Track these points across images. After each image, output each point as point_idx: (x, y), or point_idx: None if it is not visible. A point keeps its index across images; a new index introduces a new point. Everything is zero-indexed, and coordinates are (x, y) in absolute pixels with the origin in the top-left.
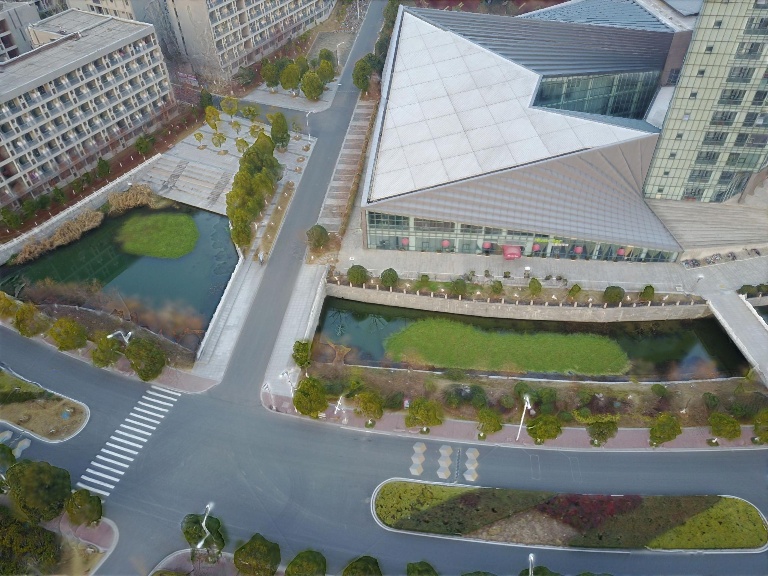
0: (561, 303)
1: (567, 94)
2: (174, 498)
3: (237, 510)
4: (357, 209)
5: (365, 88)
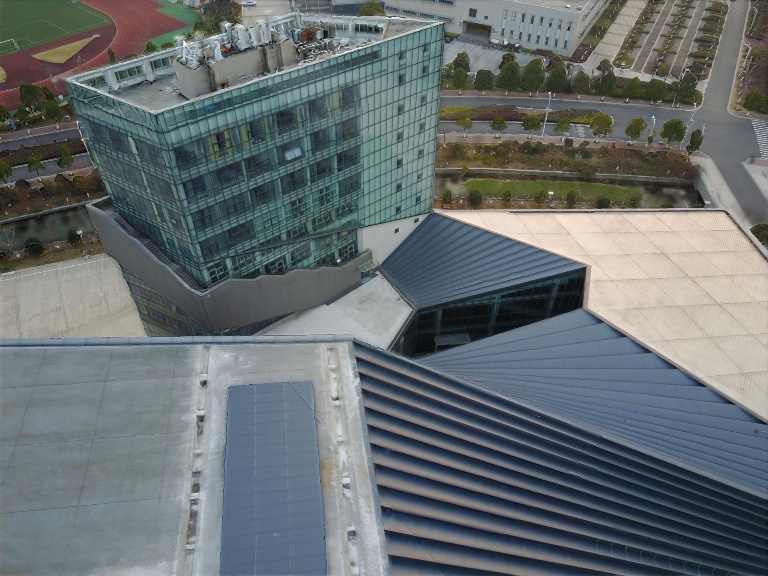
0: (516, 196)
1: None
2: (717, 122)
3: None
4: None
5: None
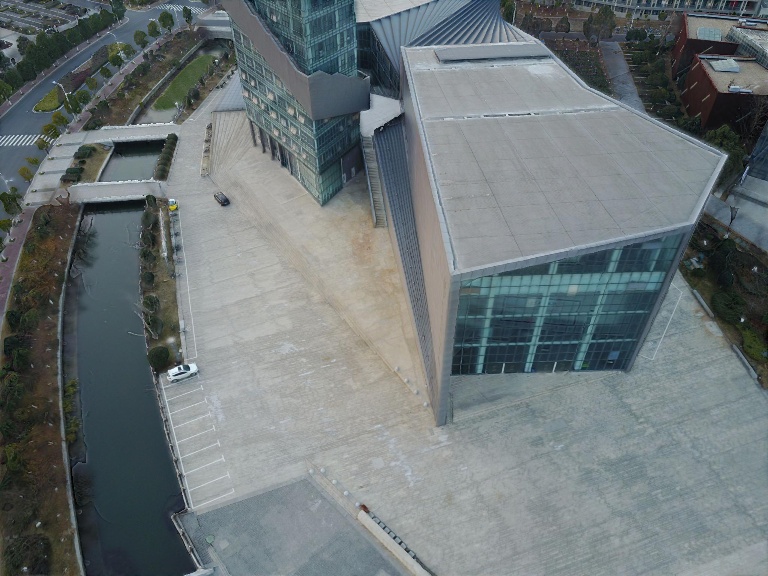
0: None
1: None
2: None
3: (137, 25)
4: None
5: None
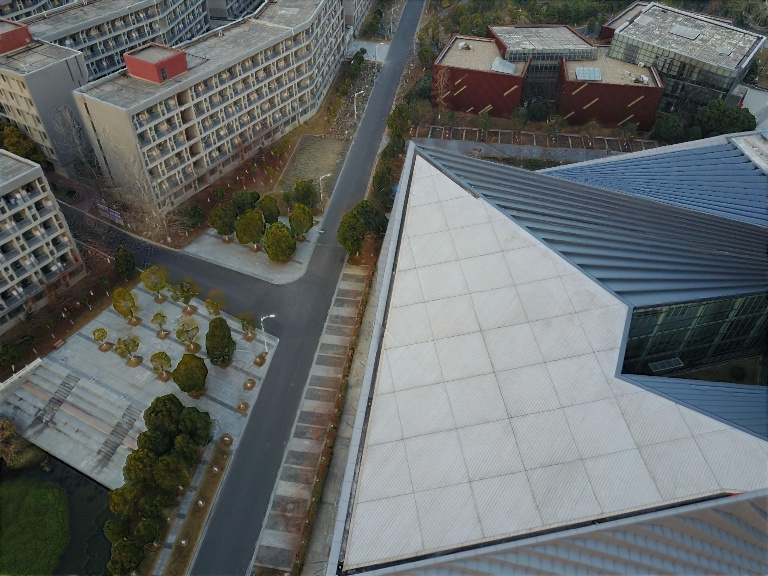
0: None
1: (664, 324)
2: None
3: None
4: (326, 510)
5: (355, 249)
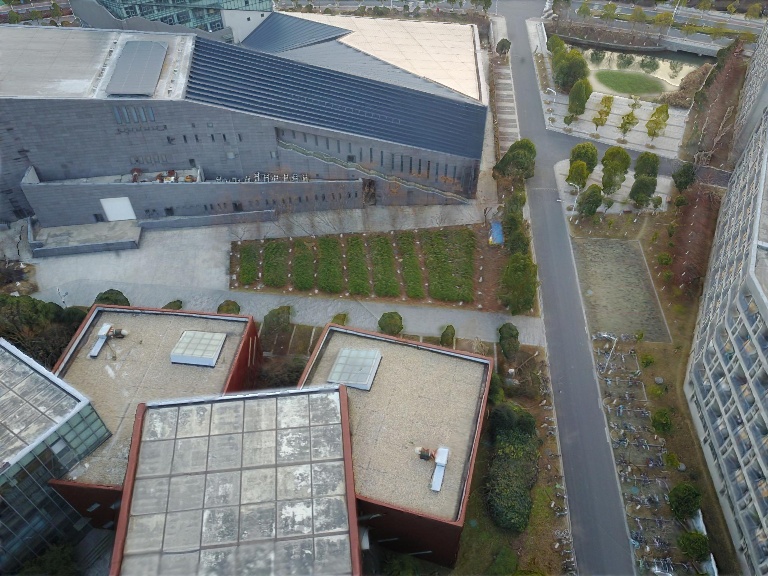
0: None
1: None
2: None
3: None
4: None
5: None
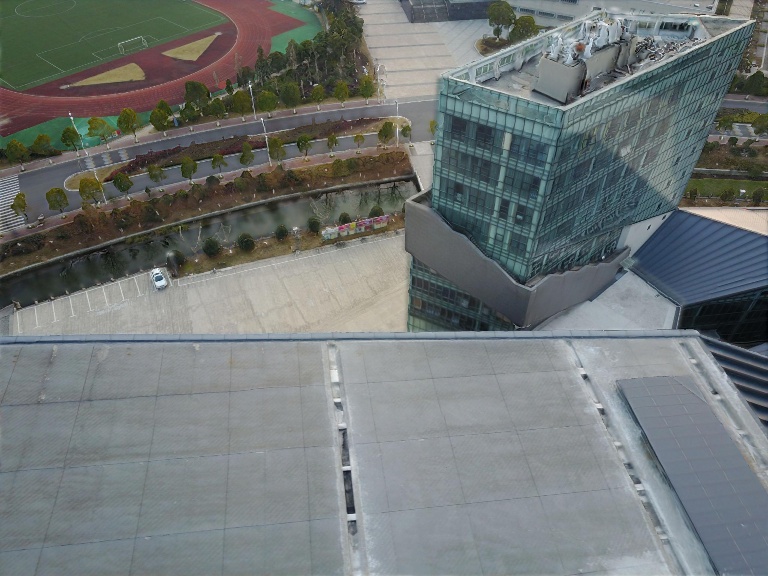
0: (699, 194)
1: None
2: None
3: None
4: None
5: None
